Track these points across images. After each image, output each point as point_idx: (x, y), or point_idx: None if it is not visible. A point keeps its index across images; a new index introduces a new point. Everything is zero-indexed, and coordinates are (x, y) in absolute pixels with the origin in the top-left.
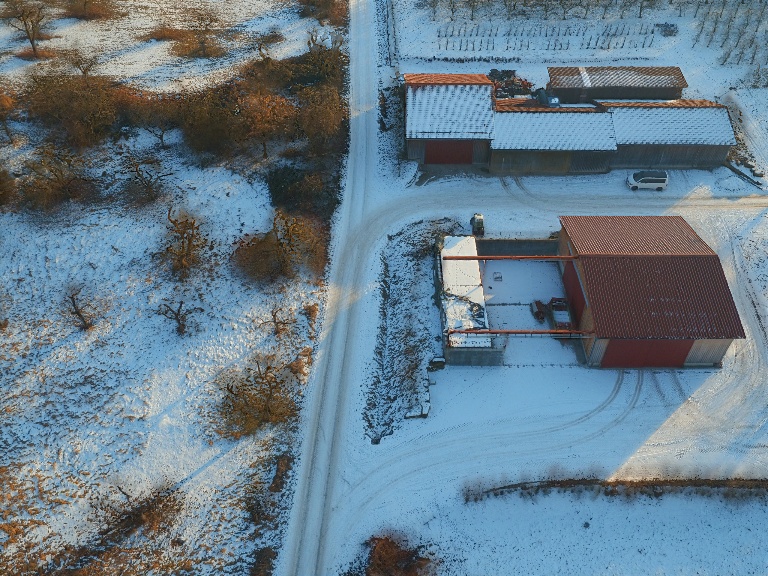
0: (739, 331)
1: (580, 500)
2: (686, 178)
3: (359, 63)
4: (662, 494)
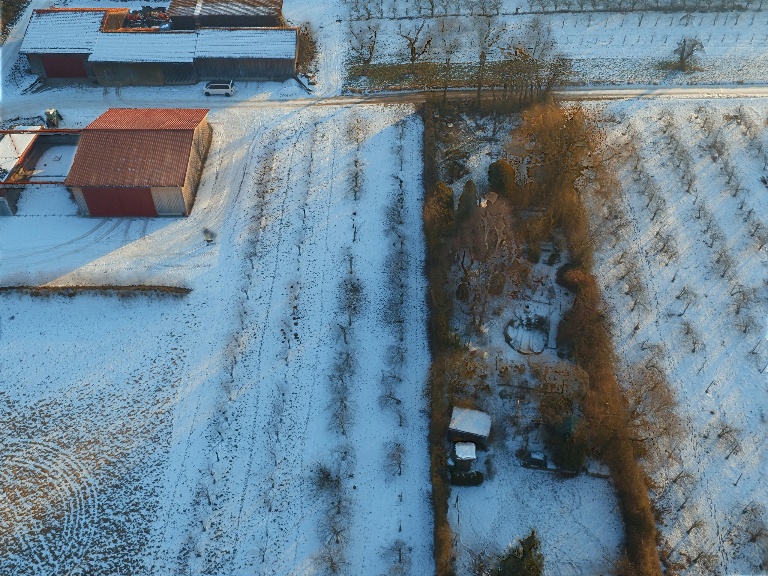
0: (180, 181)
1: (11, 300)
2: (258, 87)
3: (39, 2)
4: (75, 295)
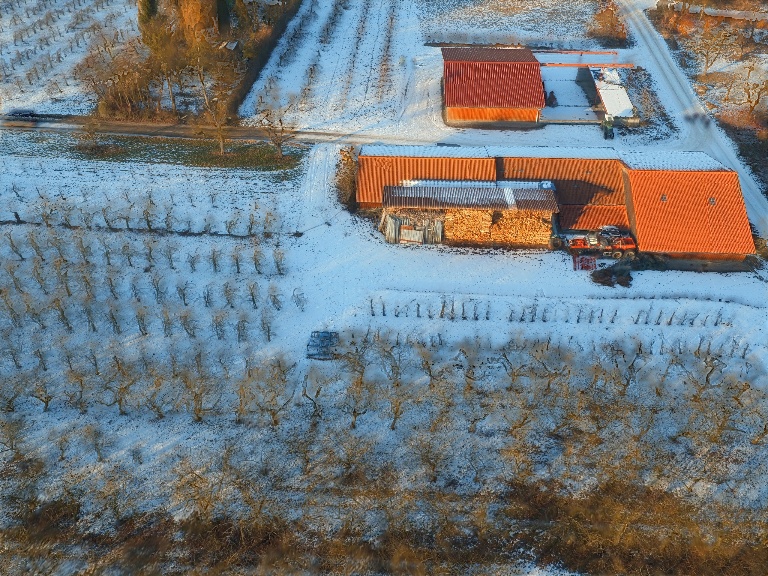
0: None
1: None
2: None
3: None
4: None
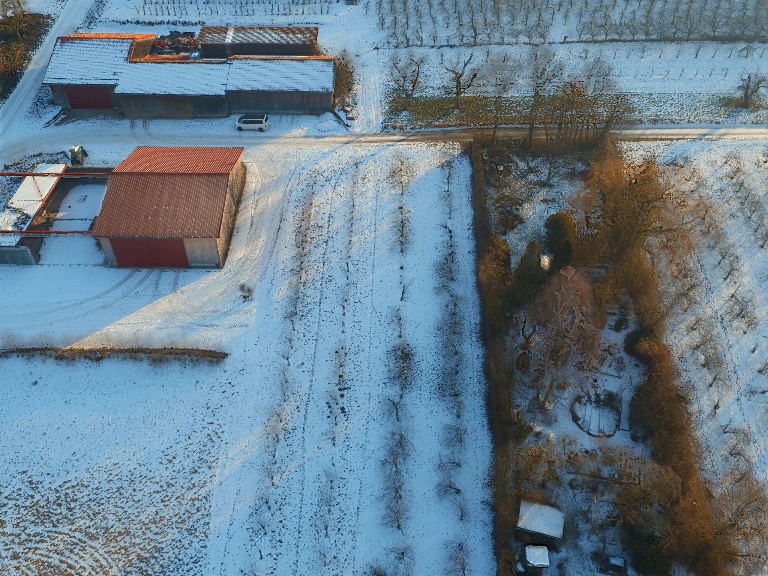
0: (216, 232)
1: (34, 363)
2: (293, 121)
3: (62, 25)
4: (103, 359)
